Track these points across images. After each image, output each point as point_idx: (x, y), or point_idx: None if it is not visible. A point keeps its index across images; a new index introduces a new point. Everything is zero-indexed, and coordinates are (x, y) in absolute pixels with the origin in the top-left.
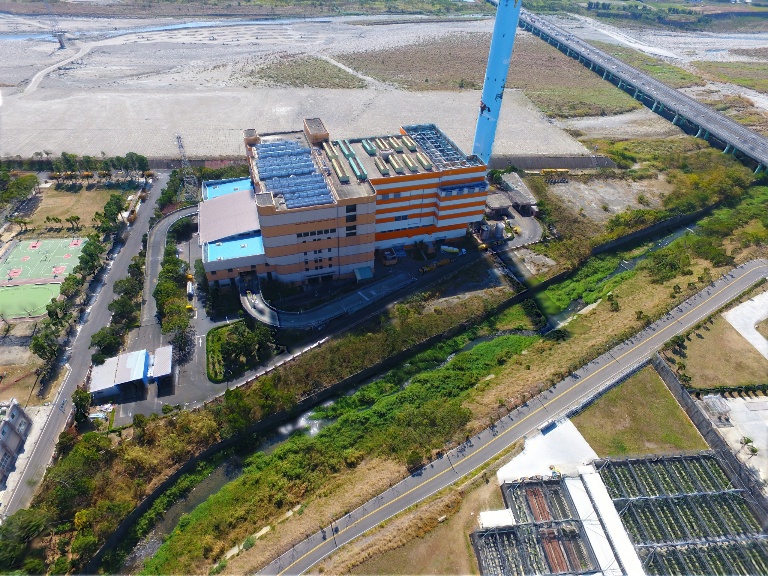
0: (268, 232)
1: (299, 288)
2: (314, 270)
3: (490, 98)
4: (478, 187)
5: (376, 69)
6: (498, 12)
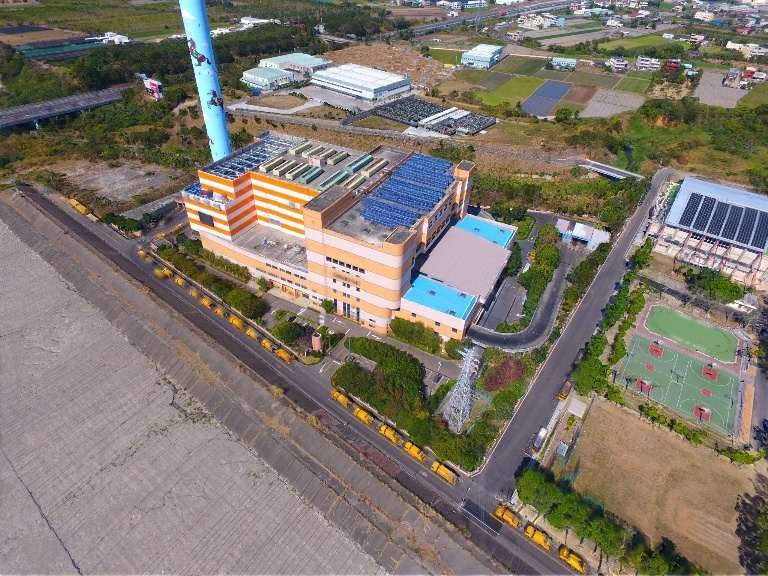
0: None
1: None
2: None
3: None
4: None
5: None
6: (201, 1)
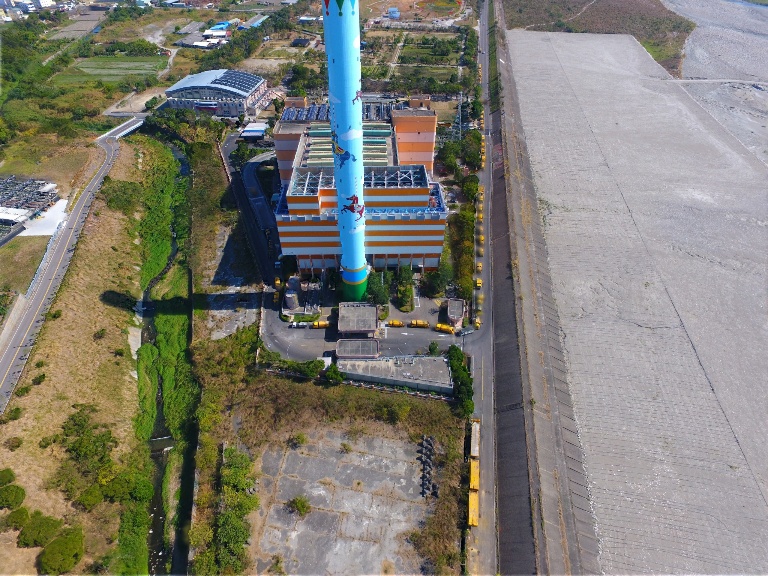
0: None
1: None
2: None
3: None
4: (278, 207)
5: None
6: None
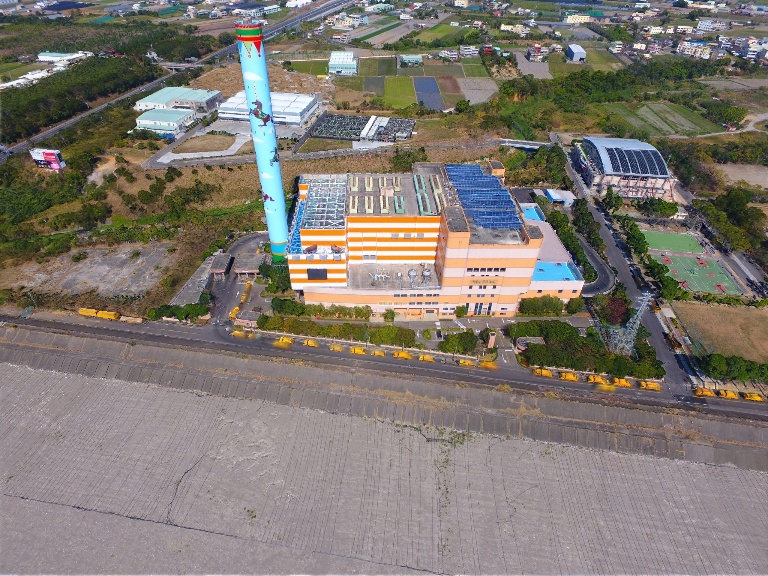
0: None
1: None
2: None
3: None
4: None
5: None
6: None
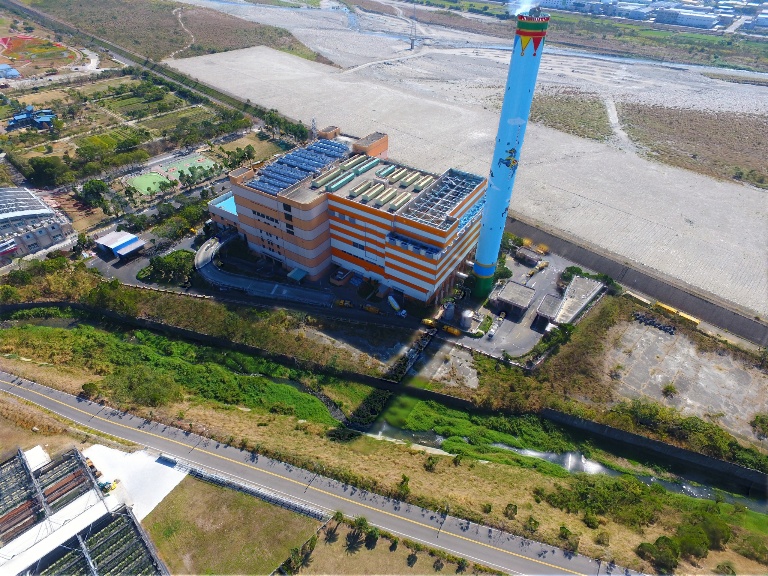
0: (235, 198)
1: (256, 258)
2: (269, 250)
3: (495, 161)
4: (425, 250)
5: (649, 127)
6: None
